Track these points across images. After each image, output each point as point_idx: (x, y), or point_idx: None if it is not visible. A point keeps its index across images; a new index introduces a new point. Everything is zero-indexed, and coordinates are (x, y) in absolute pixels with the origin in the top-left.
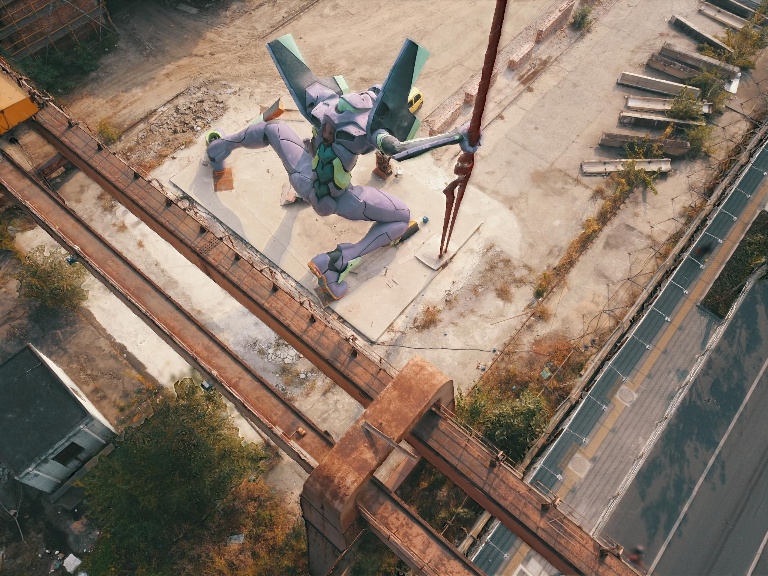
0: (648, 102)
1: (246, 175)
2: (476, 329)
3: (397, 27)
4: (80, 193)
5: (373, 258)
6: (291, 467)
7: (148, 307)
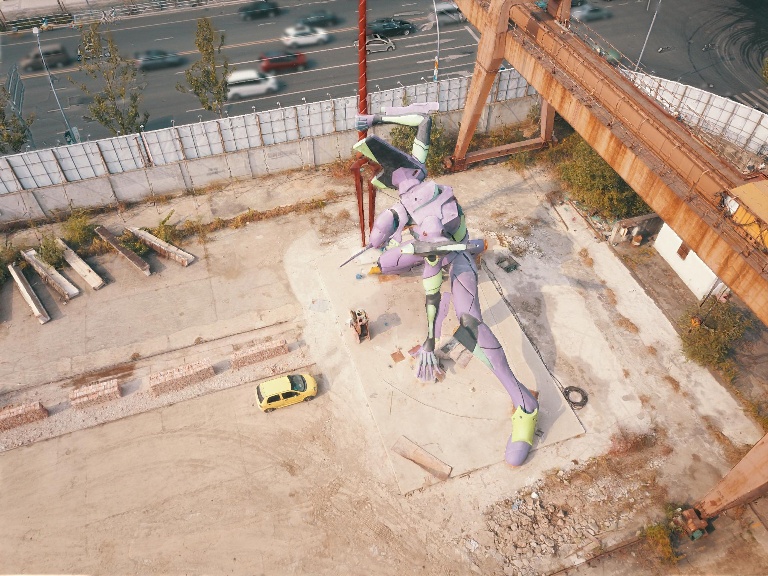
0: (61, 283)
1: (499, 396)
2: (381, 206)
3: (173, 546)
4: (695, 468)
5: (422, 270)
6: (542, 190)
7: (631, 87)
